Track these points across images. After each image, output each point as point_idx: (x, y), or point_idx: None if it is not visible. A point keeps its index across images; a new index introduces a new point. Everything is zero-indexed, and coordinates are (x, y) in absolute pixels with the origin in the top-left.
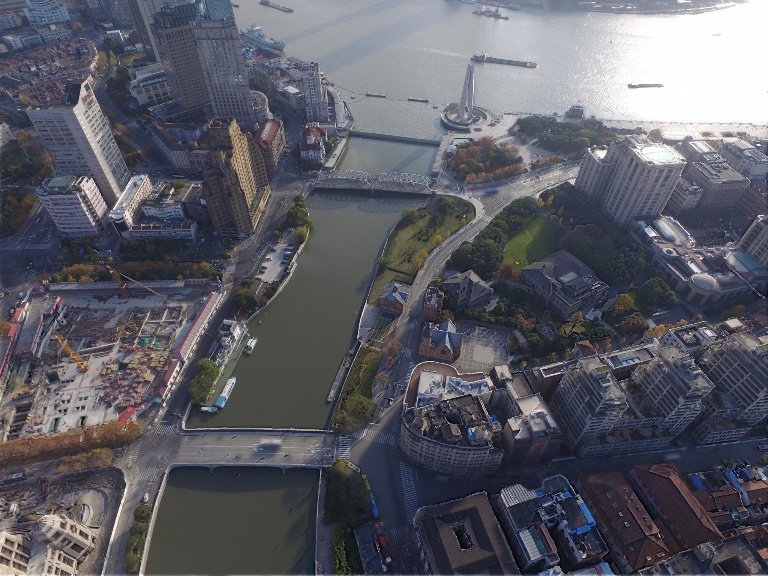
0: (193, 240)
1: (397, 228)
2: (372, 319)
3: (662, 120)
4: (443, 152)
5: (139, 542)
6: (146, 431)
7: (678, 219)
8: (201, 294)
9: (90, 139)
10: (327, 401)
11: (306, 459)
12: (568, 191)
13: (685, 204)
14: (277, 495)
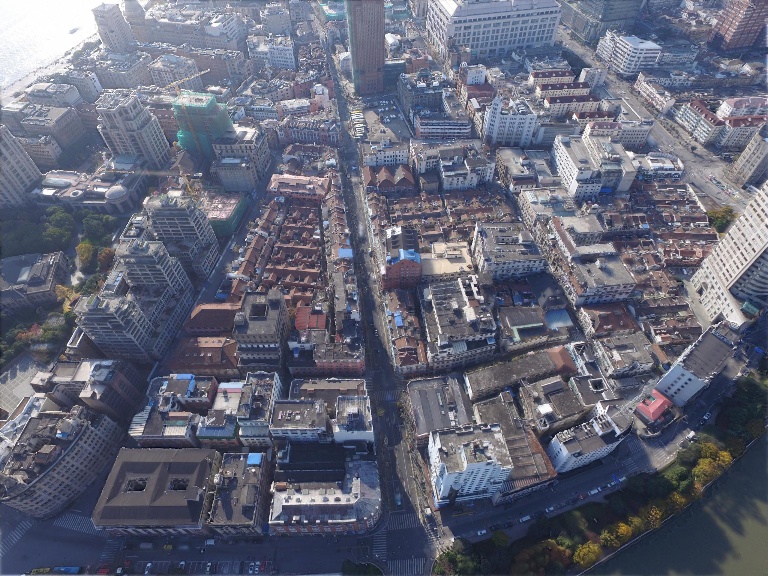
0: None
1: None
2: None
3: None
4: None
5: None
6: None
7: (61, 168)
8: None
9: None
10: None
11: None
12: None
13: (53, 155)
14: None
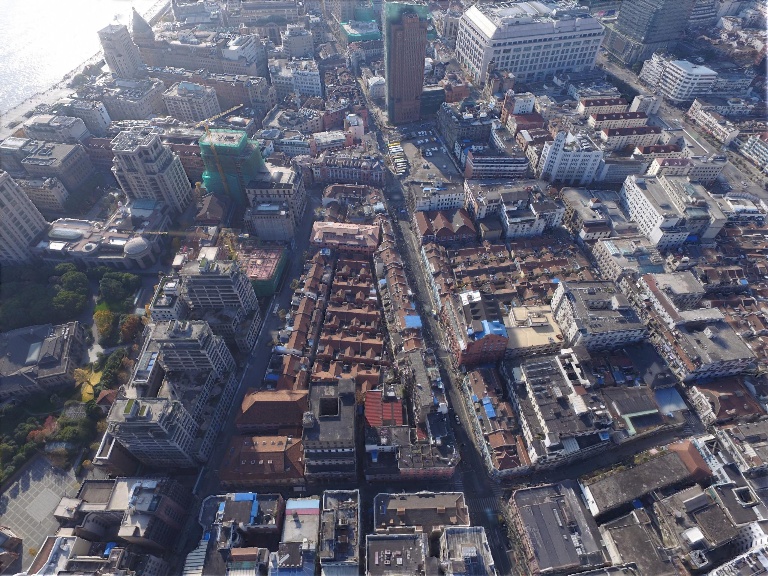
0: None
1: None
2: None
3: None
4: None
5: None
6: None
7: (69, 214)
8: None
9: None
10: None
11: None
12: None
13: (58, 198)
14: None
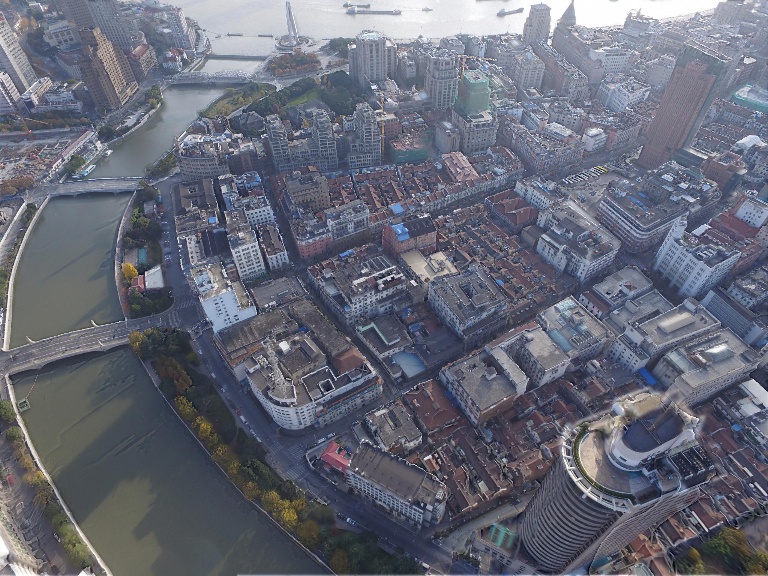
0: (80, 113)
1: (219, 99)
2: None
3: (431, 37)
4: (267, 61)
5: (29, 215)
6: (38, 184)
7: (404, 84)
8: (81, 135)
9: (4, 48)
10: (148, 170)
11: (128, 187)
12: (340, 75)
13: (408, 75)
14: (110, 202)
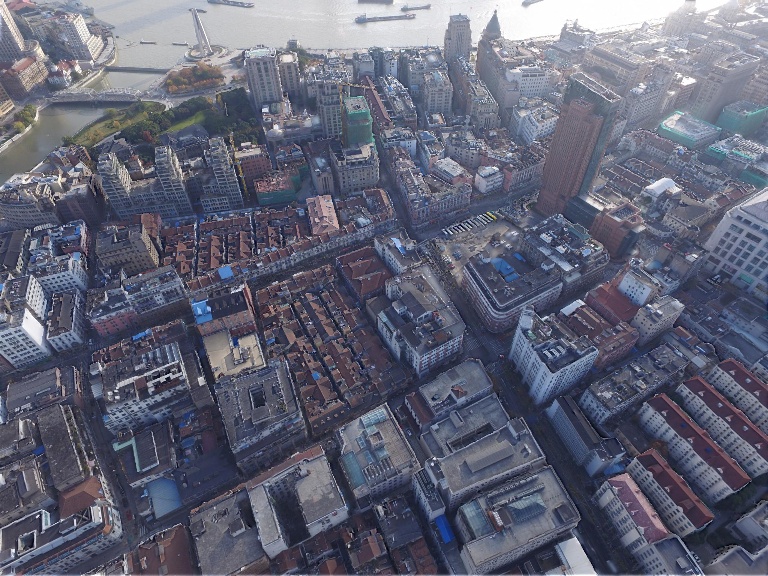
0: None
1: (96, 122)
2: (41, 170)
3: (355, 47)
4: (167, 75)
5: None
6: None
7: (305, 105)
8: None
9: None
10: None
11: None
12: (237, 93)
13: (310, 94)
14: None
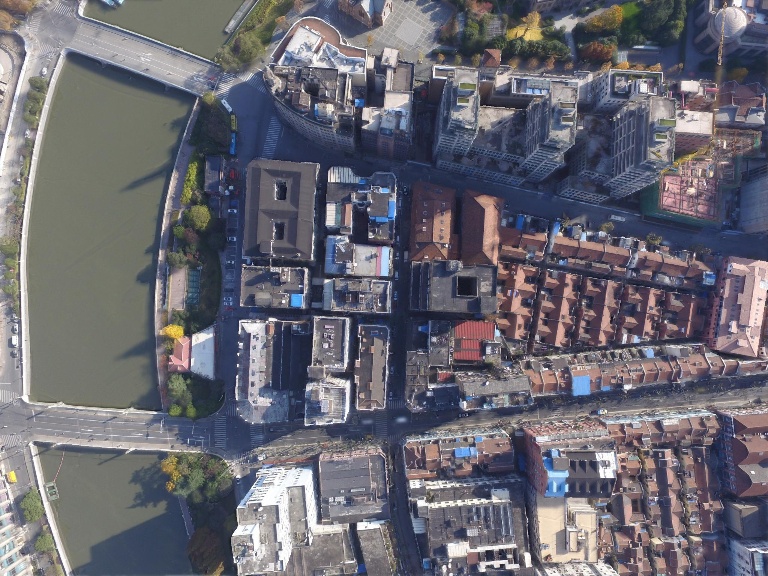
0: None
1: None
2: None
3: None
4: None
5: (34, 106)
6: (44, 5)
7: None
8: None
9: None
10: (224, 31)
11: (187, 83)
12: None
13: None
14: (157, 107)
